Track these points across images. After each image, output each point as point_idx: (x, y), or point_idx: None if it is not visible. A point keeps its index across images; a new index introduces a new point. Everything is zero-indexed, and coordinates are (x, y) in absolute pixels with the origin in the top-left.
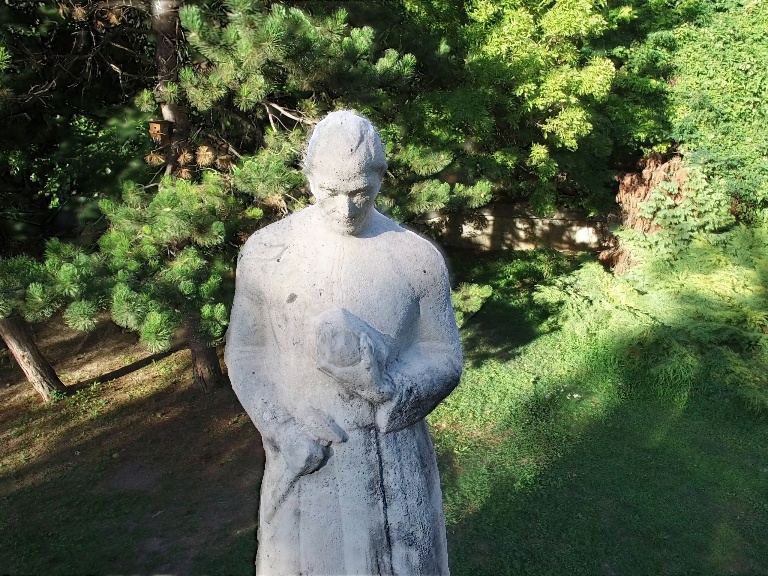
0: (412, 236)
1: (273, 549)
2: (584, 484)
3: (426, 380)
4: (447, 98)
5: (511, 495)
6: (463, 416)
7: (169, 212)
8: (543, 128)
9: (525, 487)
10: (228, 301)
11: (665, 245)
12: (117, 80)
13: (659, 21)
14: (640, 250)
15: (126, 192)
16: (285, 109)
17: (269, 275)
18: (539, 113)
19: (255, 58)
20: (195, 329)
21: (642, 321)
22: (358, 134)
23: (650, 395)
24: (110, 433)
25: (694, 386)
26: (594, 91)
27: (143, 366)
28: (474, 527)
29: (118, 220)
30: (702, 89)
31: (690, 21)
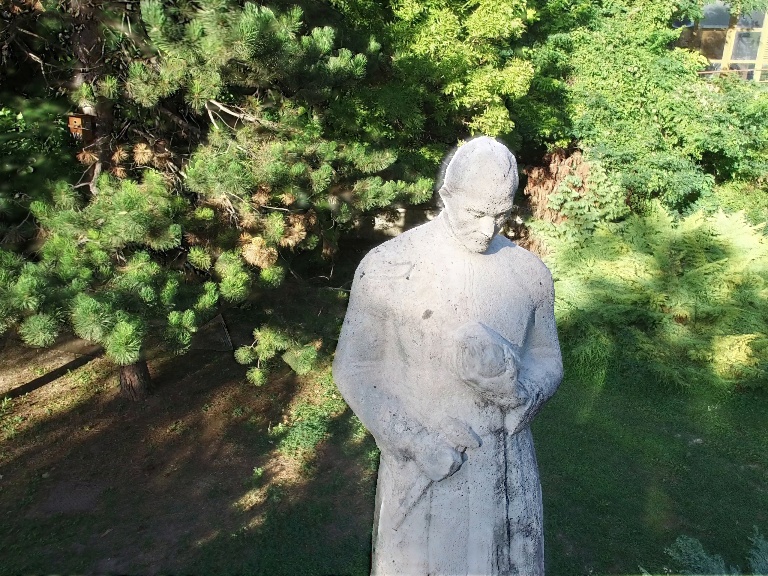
0: (523, 251)
1: (400, 555)
2: None
3: (547, 385)
4: (378, 95)
5: None
6: None
7: (125, 216)
8: (470, 126)
9: None
10: (188, 307)
11: (572, 234)
12: (39, 71)
13: (558, 24)
14: (552, 240)
15: (59, 193)
16: (224, 105)
17: (399, 293)
18: (463, 111)
19: (223, 57)
20: (159, 338)
21: (560, 306)
22: (508, 161)
23: (572, 375)
24: (34, 452)
25: (610, 364)
26: (516, 91)
27: (57, 377)
28: None
29: (58, 224)
30: (597, 89)
31: (584, 25)
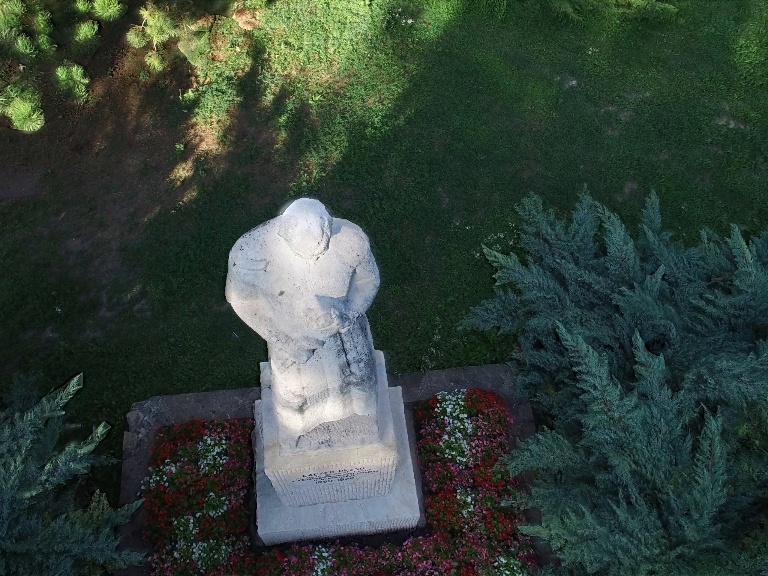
0: (346, 232)
1: (286, 381)
2: (421, 119)
3: (365, 307)
4: None
5: (365, 141)
6: (310, 59)
7: None
8: None
9: (375, 131)
10: (69, 40)
11: None
12: None
13: None
14: None
15: None
16: None
17: (261, 279)
18: None
19: None
20: (55, 87)
21: None
22: (321, 232)
23: (474, 7)
24: None
25: None
26: None
27: None
28: (340, 177)
29: None
30: None
31: None
